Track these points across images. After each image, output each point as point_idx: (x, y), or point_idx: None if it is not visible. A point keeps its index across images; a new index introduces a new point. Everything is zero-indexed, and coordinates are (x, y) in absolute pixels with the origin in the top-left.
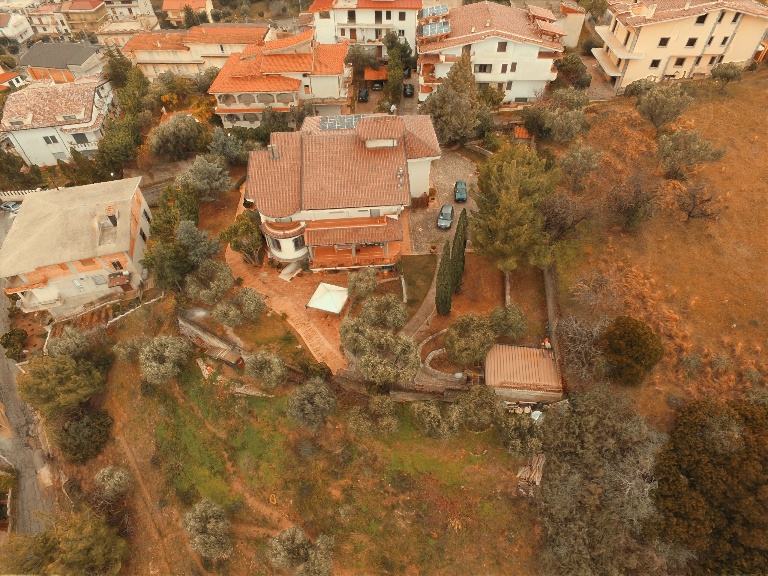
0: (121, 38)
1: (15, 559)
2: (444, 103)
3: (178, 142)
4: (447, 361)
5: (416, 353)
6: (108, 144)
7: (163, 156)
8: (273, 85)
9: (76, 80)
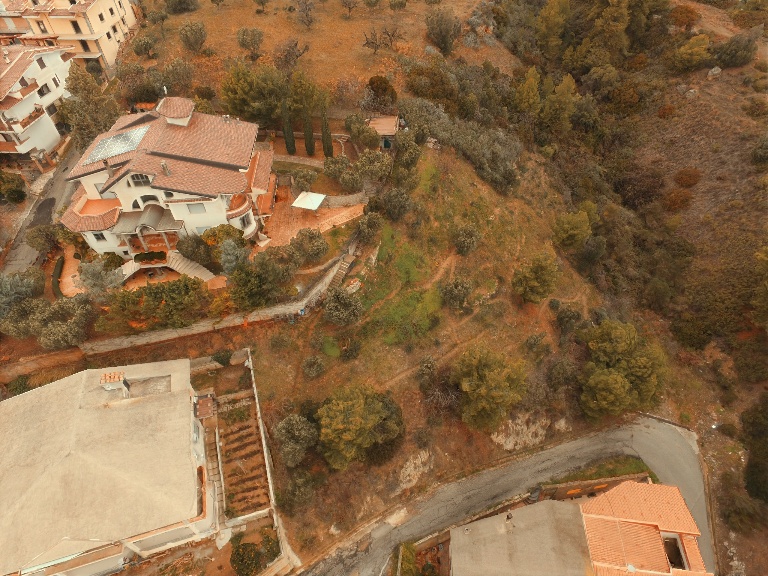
0: None
1: None
2: None
3: None
4: None
5: None
6: None
7: None
8: None
9: None
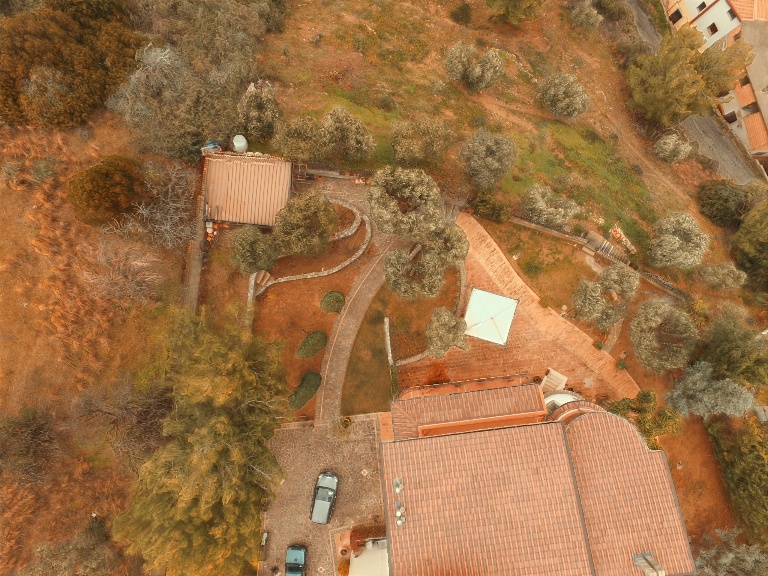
0: None
1: (728, 54)
2: None
3: None
4: None
5: (371, 203)
6: None
7: None
8: None
9: None
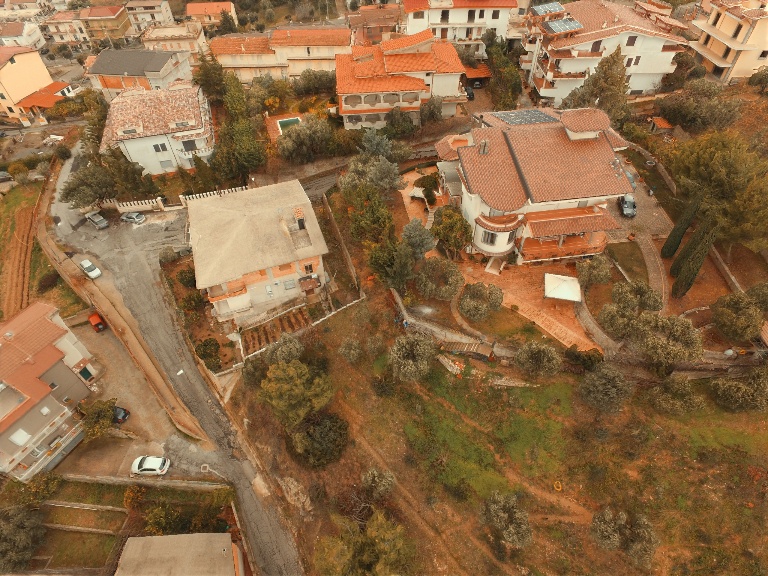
0: (169, 44)
1: (342, 564)
2: (591, 97)
3: (312, 144)
4: (709, 340)
5: None
6: (239, 149)
7: (293, 159)
8: (400, 85)
9: (171, 86)
